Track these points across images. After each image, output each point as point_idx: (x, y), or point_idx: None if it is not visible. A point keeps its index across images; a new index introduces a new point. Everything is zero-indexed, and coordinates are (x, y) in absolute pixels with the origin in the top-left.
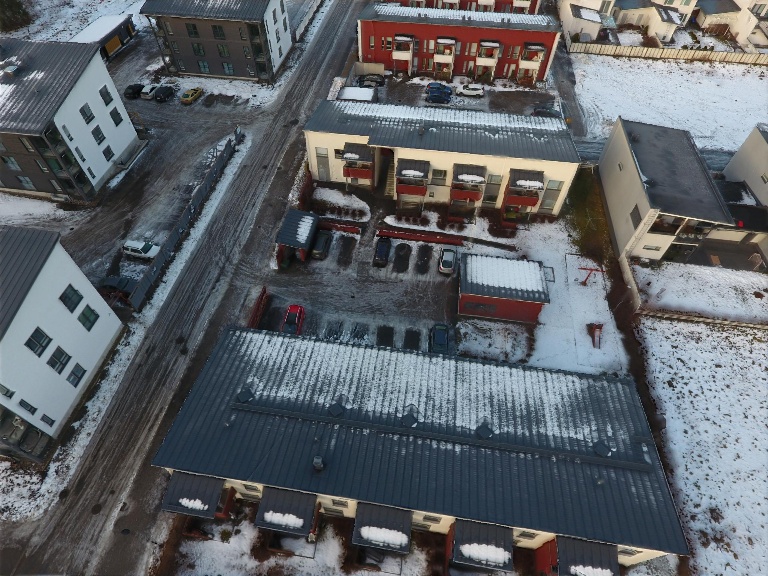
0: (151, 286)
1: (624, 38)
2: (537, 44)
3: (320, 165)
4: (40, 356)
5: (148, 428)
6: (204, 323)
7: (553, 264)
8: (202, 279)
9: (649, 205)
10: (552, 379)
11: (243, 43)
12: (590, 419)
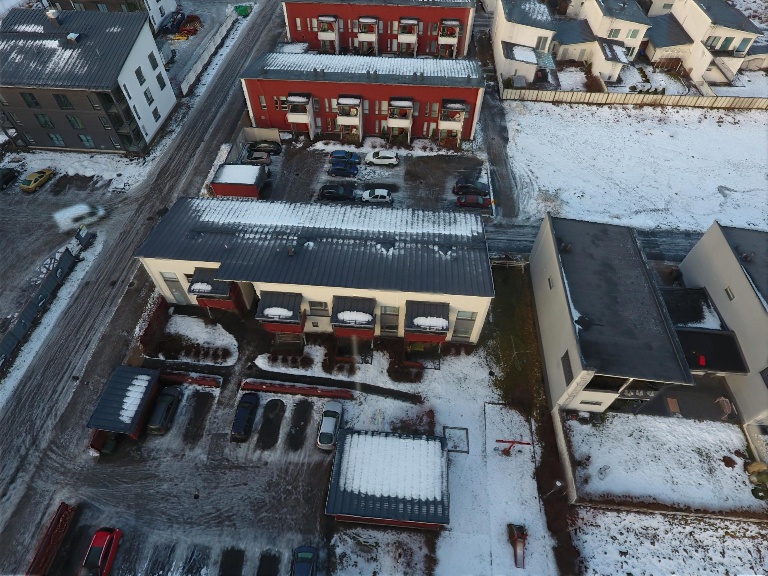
0: None
1: (565, 78)
2: (457, 101)
3: (172, 289)
4: None
5: None
6: None
7: (468, 422)
8: None
9: (581, 364)
10: None
11: (97, 113)
12: None
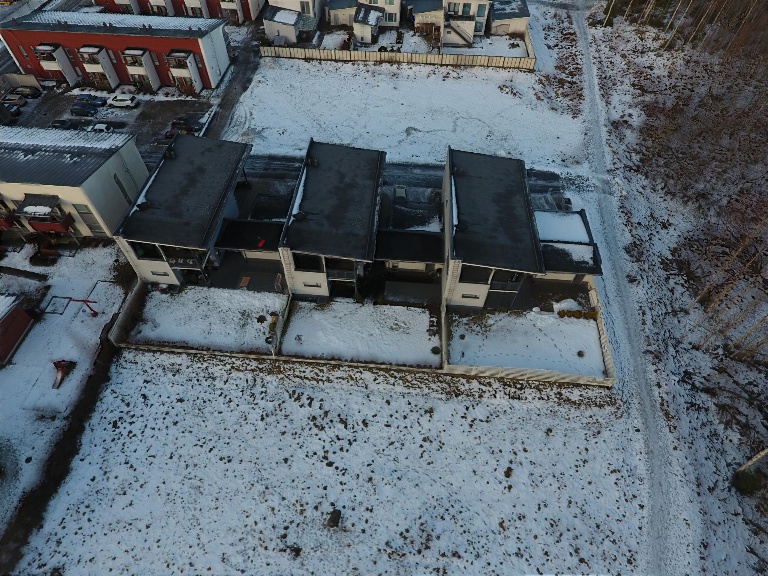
0: None
1: (329, 40)
2: (184, 51)
3: None
4: None
5: None
6: None
7: (75, 294)
8: None
9: None
10: None
11: None
12: None
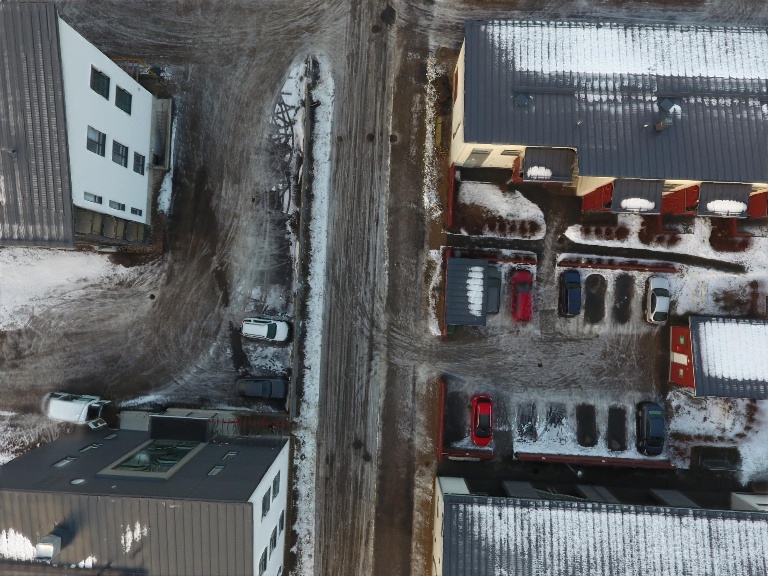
0: (296, 379)
1: None
2: None
3: (472, 158)
4: (266, 568)
5: (364, 544)
6: (376, 420)
7: None
8: (352, 358)
9: None
10: None
11: None
12: None
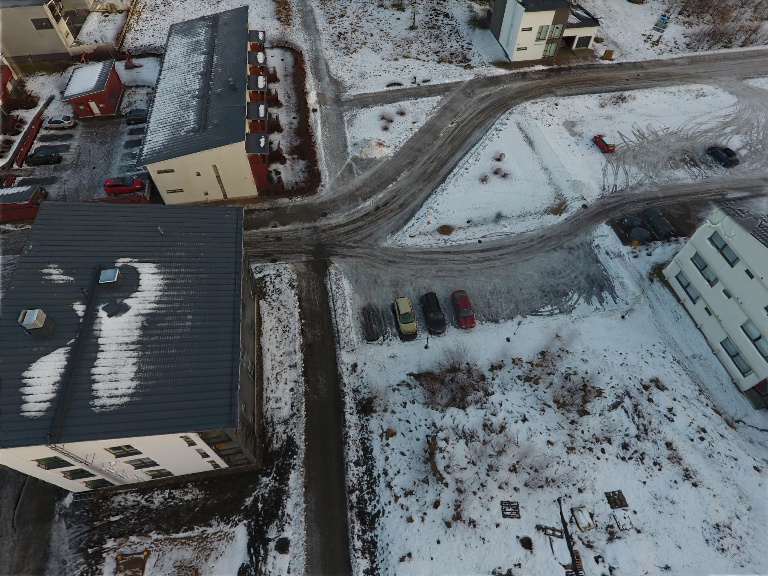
0: None
1: None
2: None
3: None
4: None
5: None
6: None
7: None
8: None
9: (39, 6)
10: (172, 43)
11: None
12: (194, 30)
